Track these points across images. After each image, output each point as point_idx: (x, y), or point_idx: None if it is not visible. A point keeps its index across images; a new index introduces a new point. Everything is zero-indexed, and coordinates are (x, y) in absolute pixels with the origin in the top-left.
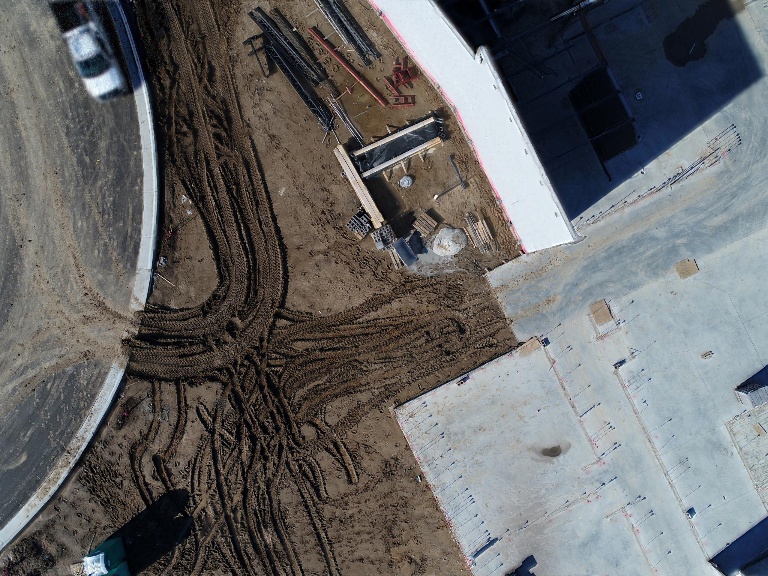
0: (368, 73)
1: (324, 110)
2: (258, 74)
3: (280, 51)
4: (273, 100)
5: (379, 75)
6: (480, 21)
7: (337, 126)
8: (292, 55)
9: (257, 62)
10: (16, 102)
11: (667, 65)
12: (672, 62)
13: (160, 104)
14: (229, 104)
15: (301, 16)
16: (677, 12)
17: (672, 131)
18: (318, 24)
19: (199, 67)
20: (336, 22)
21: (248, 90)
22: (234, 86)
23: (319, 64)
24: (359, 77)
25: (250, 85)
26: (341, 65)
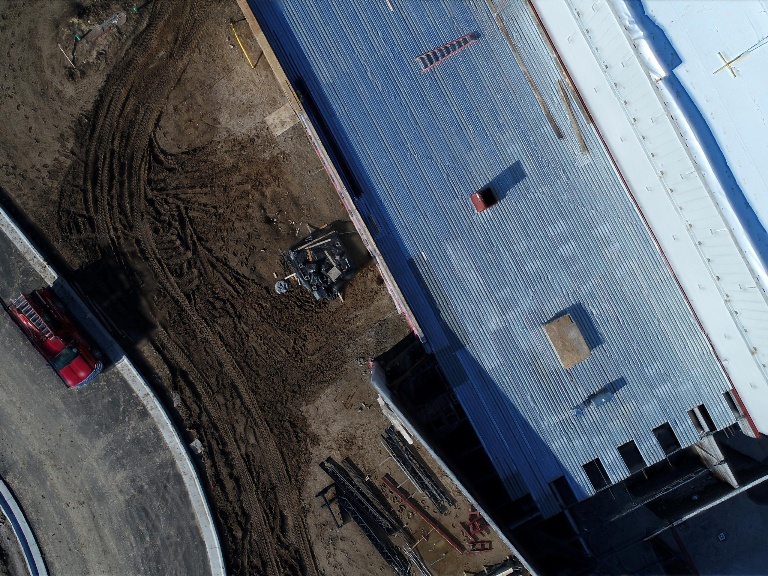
0: (443, 519)
1: (400, 558)
2: (332, 524)
3: (353, 502)
4: (348, 550)
5: (455, 521)
6: (570, 541)
7: (414, 574)
8: (366, 505)
9: (330, 513)
10: (87, 557)
11: (749, 504)
12: (755, 501)
13: (233, 556)
14: (303, 553)
15: (373, 464)
16: (758, 450)
17: (757, 571)
18: (391, 471)
19: (271, 518)
20: (410, 472)
21: (322, 540)
22: (308, 536)
23: (393, 512)
24: (435, 525)
25: (324, 535)
26: (416, 512)
